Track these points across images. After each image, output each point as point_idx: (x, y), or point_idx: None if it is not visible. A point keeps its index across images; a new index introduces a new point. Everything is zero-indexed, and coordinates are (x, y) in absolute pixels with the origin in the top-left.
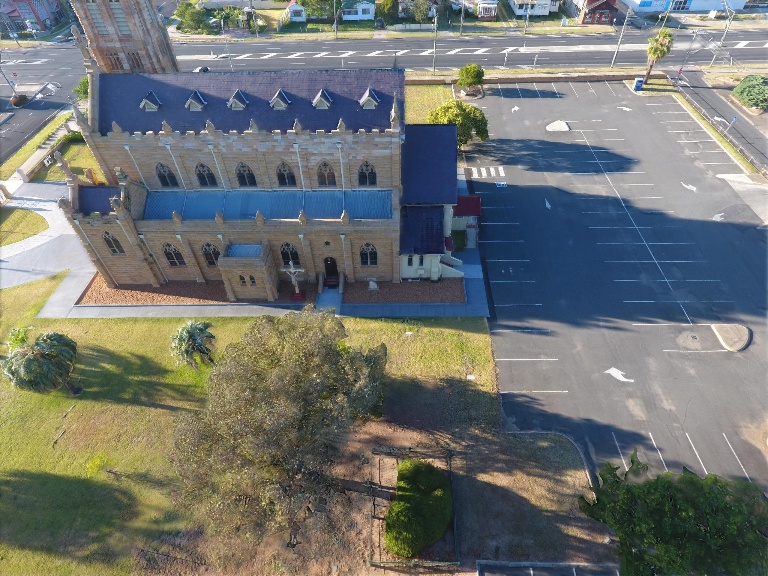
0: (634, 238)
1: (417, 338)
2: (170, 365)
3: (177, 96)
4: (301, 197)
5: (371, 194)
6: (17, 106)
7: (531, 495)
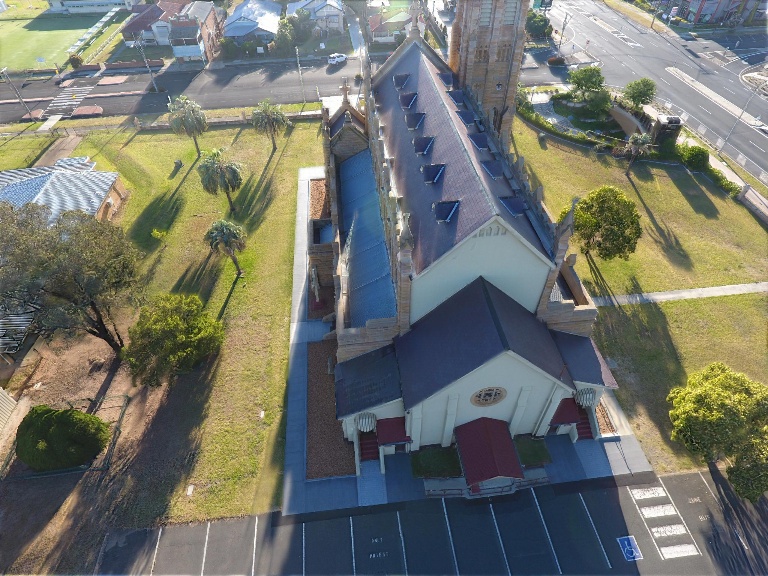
0: None
1: (254, 424)
2: (247, 245)
3: (410, 89)
4: (378, 242)
5: (391, 300)
6: (549, 64)
7: (26, 558)
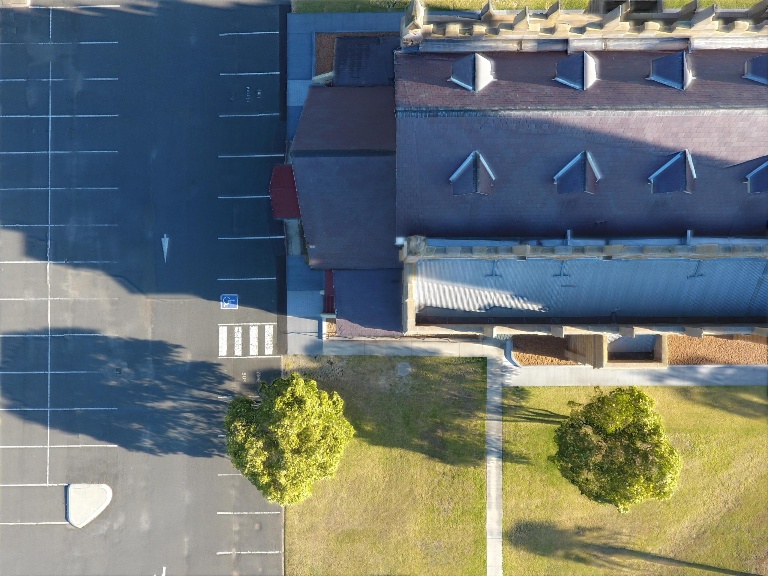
0: (62, 164)
1: None
2: None
3: None
4: None
5: None
6: None
7: None
